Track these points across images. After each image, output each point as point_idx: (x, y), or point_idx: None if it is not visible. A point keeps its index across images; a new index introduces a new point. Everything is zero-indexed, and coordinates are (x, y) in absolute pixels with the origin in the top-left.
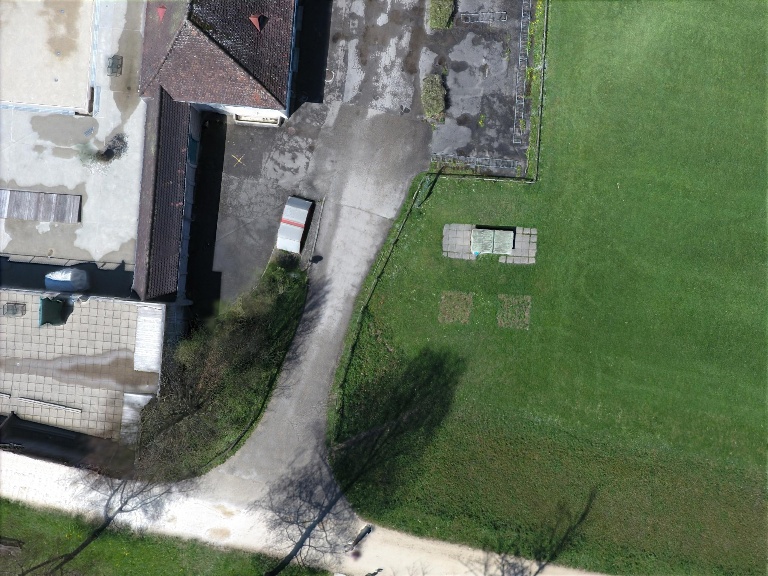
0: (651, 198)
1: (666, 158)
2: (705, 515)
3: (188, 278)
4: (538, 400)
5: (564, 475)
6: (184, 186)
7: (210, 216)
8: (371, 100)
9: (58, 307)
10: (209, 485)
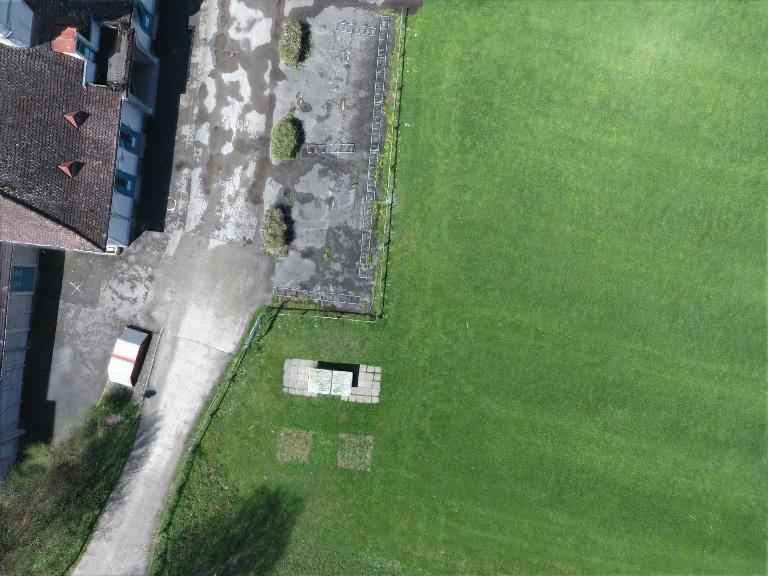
0: (501, 339)
1: (518, 298)
2: None
3: (22, 406)
4: (378, 545)
5: None
6: (5, 323)
7: (46, 344)
8: (213, 230)
9: None
10: None
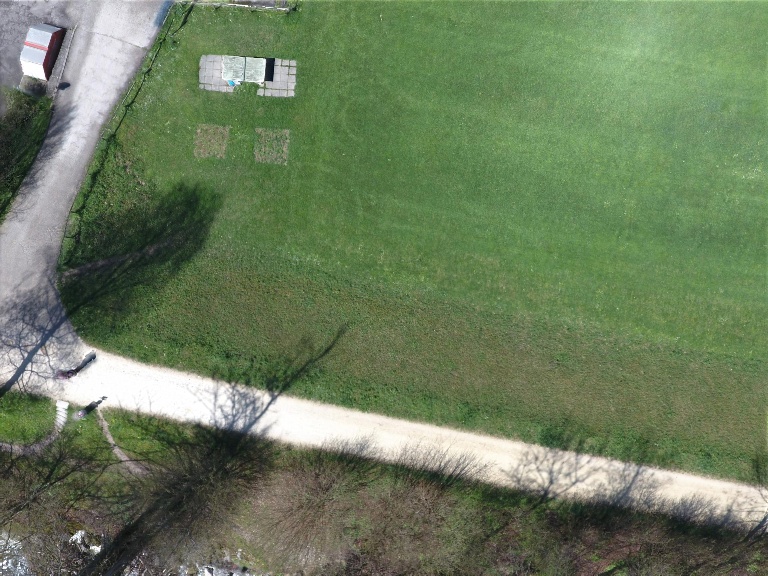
0: (415, 30)
1: None
2: (460, 355)
3: None
4: (297, 239)
5: (315, 312)
6: None
7: None
8: None
9: None
10: None
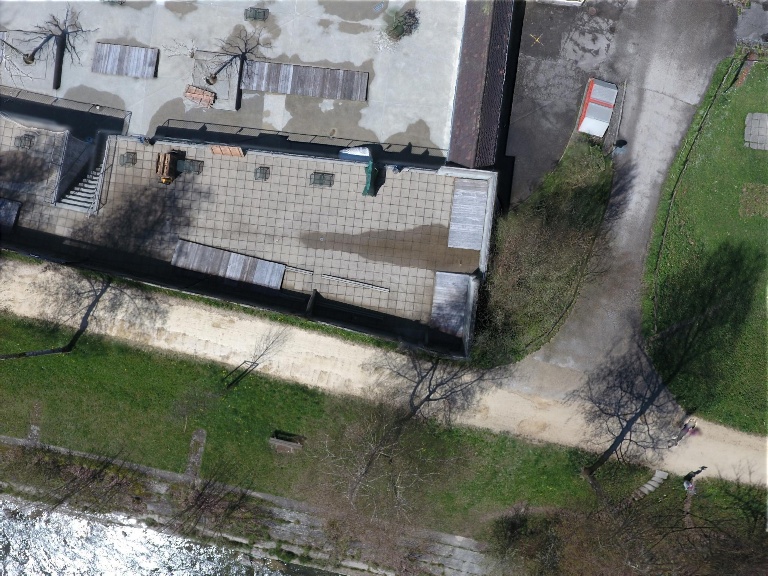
0: None
1: None
2: None
3: None
4: None
5: None
6: (506, 54)
7: (505, 97)
8: None
9: (374, 176)
10: (524, 373)
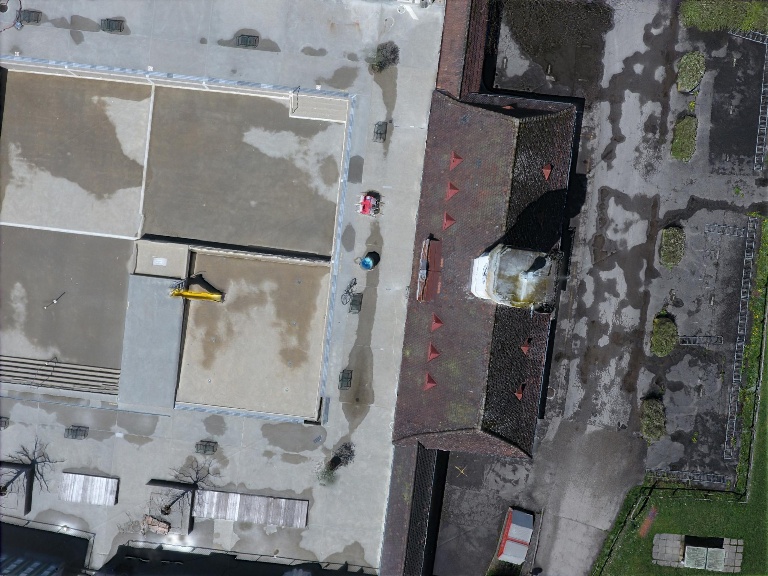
0: None
1: None
2: None
3: None
4: None
5: None
6: (427, 521)
7: (433, 524)
8: (590, 417)
9: None
10: None
